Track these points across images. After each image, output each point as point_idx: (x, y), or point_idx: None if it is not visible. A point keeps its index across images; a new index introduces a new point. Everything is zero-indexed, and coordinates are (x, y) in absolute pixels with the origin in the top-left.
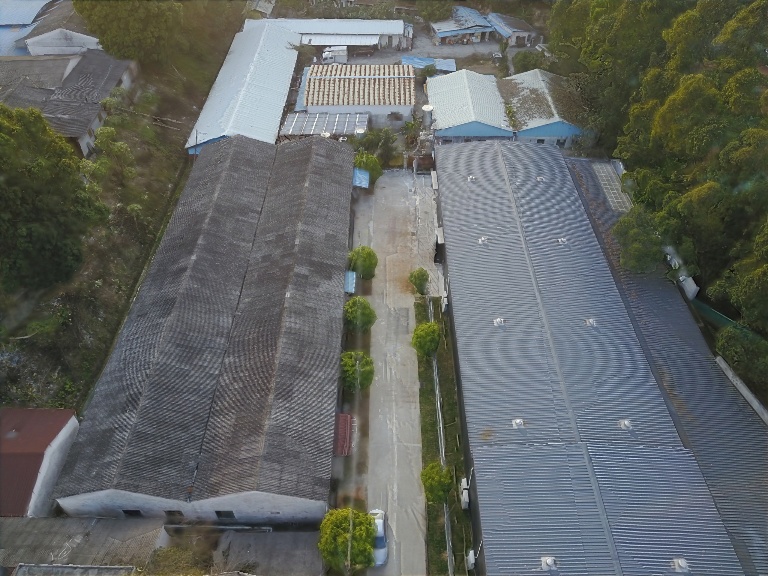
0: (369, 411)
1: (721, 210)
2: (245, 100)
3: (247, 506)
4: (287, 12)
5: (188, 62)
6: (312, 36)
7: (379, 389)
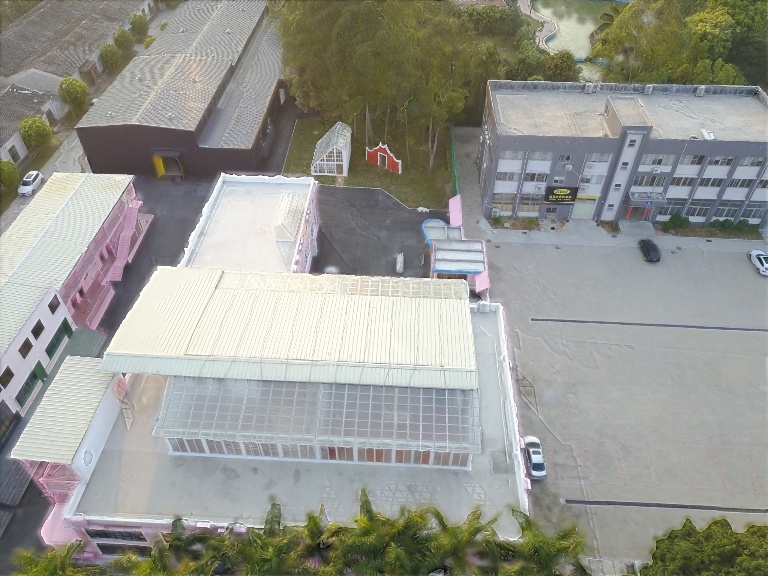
0: None
1: None
2: None
3: (34, 85)
4: None
5: None
6: None
7: None
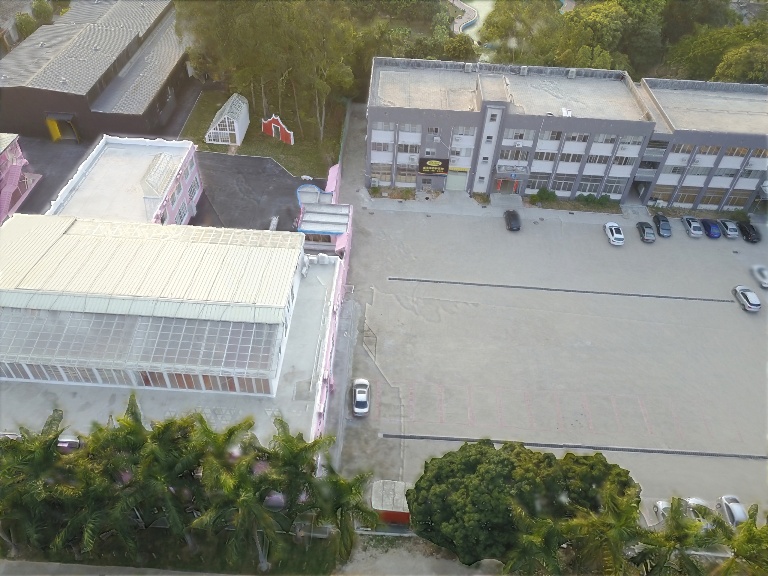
0: None
1: None
2: None
3: None
4: None
5: None
6: None
7: None
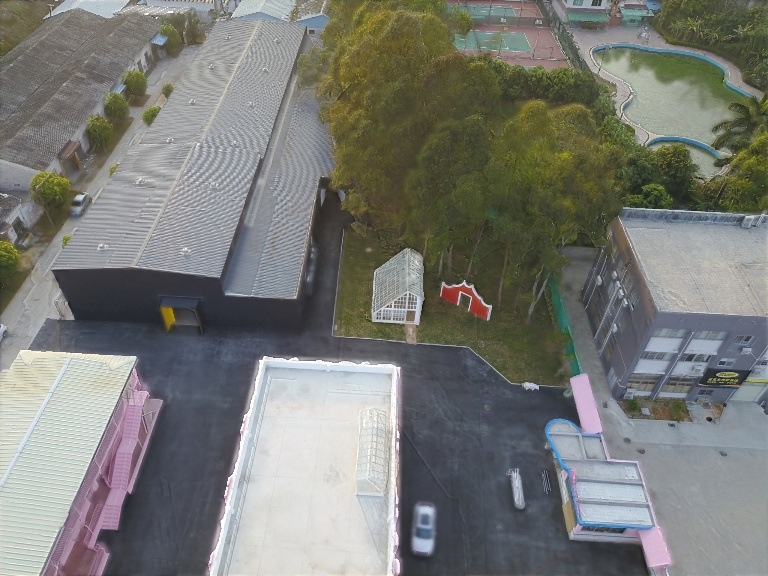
0: (108, 158)
1: None
2: None
3: None
4: None
5: None
6: None
7: (121, 149)
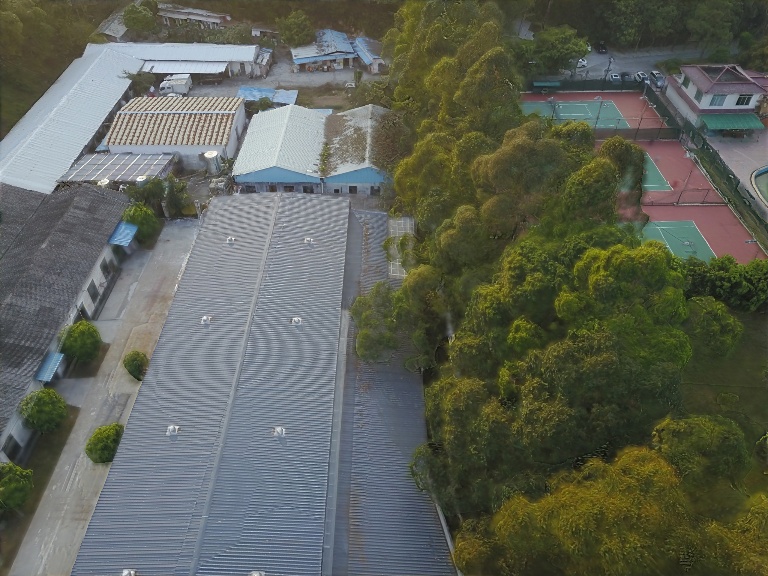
0: (27, 532)
1: (442, 297)
2: (37, 139)
3: None
4: (149, 34)
5: (3, 93)
6: (156, 63)
7: (51, 502)
